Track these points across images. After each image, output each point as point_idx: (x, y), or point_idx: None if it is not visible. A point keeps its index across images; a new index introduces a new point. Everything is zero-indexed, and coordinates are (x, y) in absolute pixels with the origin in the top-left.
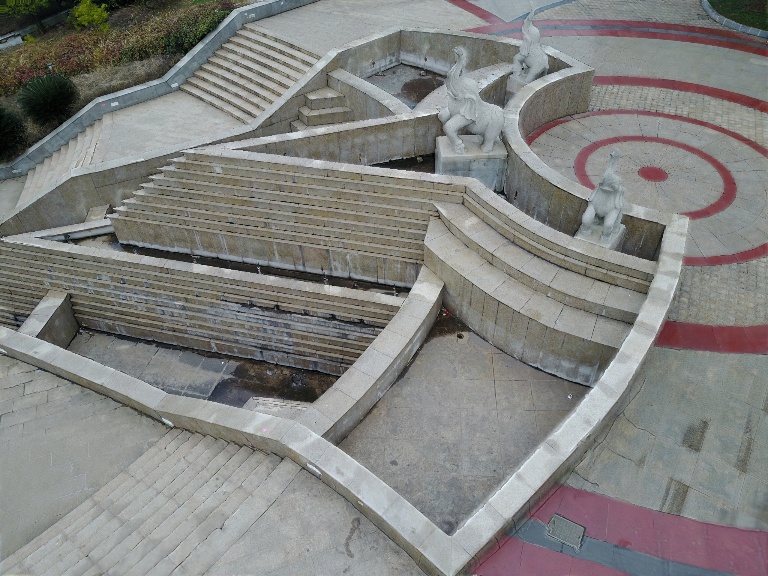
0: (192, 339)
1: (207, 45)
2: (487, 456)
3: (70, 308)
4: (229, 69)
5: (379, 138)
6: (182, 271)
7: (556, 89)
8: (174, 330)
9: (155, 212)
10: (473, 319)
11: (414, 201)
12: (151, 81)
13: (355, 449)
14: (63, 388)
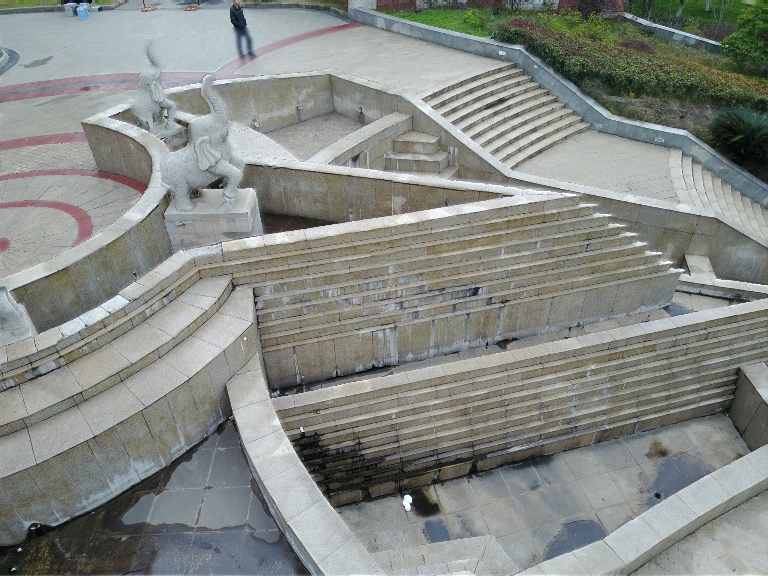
0: None
1: None
2: None
3: None
4: None
5: None
6: None
7: None
8: None
9: None
10: None
11: None
12: None
13: None
14: None
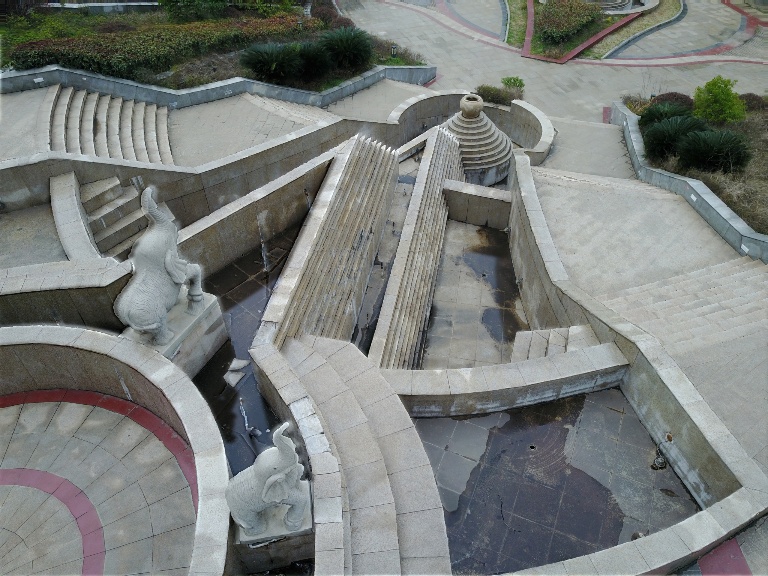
0: None
1: None
2: None
3: None
4: None
5: None
6: None
7: None
8: None
9: None
10: None
11: None
12: (745, 223)
13: (50, 218)
14: None
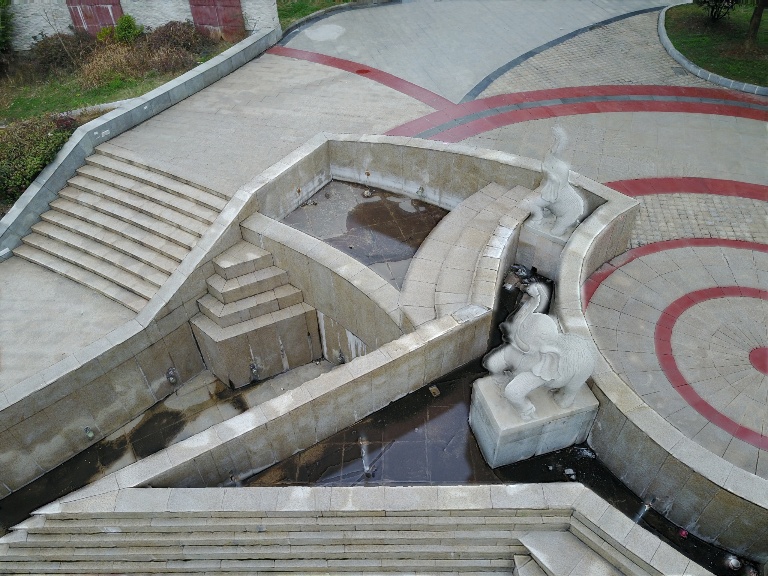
0: None
1: (45, 186)
2: None
3: None
4: (85, 219)
5: (374, 384)
6: None
7: (597, 240)
8: None
9: None
10: None
11: (484, 539)
12: None
13: None
14: None
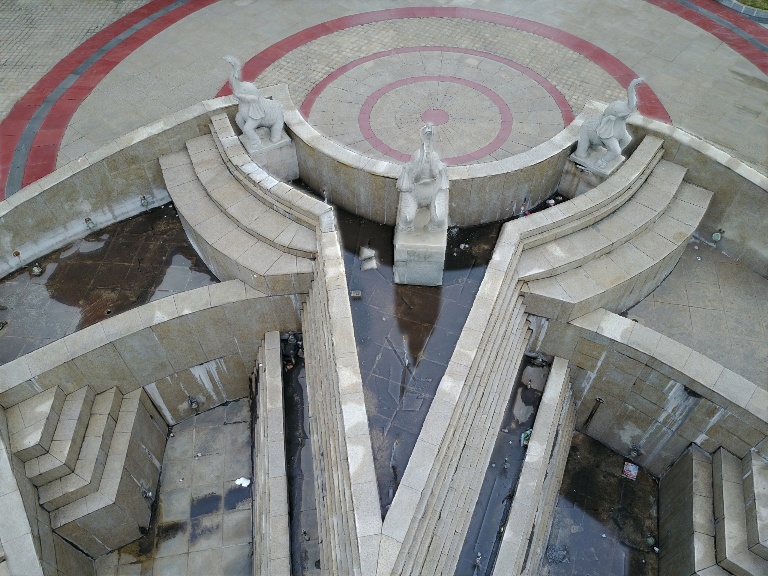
0: None
1: None
2: None
3: None
4: None
5: None
6: None
7: None
8: None
9: None
10: None
11: None
12: None
13: None
14: None
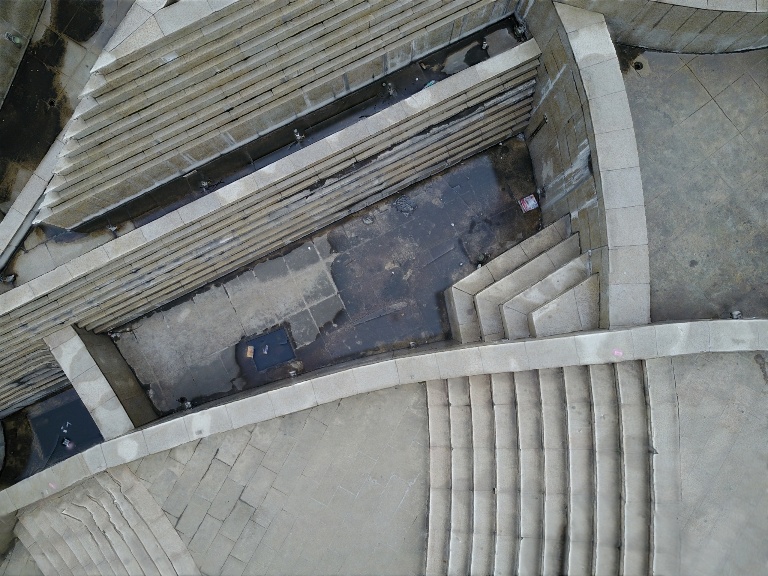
0: (259, 254)
1: None
2: (767, 192)
3: (87, 333)
4: None
5: None
6: (213, 211)
7: None
8: (231, 261)
9: (104, 170)
10: (652, 38)
11: None
12: None
13: None
14: (259, 429)
